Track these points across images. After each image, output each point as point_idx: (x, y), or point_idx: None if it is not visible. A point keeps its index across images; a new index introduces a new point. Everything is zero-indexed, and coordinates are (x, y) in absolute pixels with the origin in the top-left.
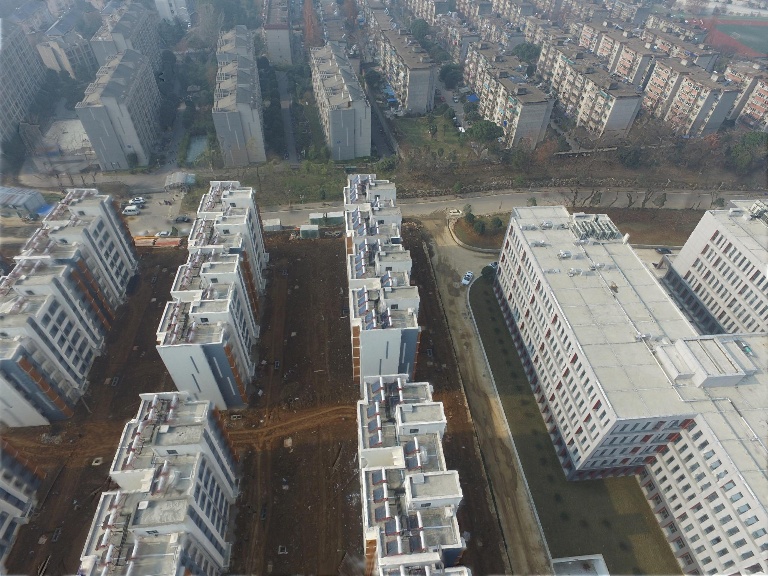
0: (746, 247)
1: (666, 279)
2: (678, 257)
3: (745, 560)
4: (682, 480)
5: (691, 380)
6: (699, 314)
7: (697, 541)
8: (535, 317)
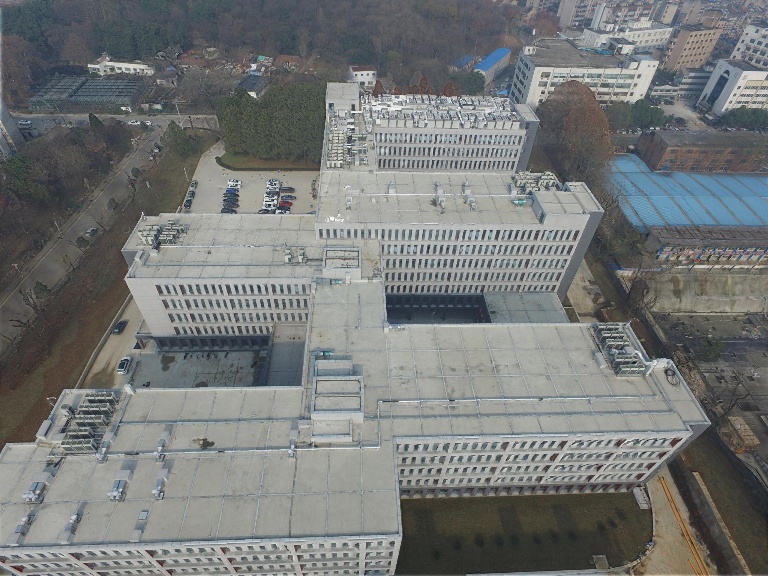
0: (196, 278)
1: (163, 348)
2: (150, 327)
3: (501, 461)
4: (423, 471)
5: (354, 425)
6: (223, 343)
7: (464, 480)
8: (190, 567)
